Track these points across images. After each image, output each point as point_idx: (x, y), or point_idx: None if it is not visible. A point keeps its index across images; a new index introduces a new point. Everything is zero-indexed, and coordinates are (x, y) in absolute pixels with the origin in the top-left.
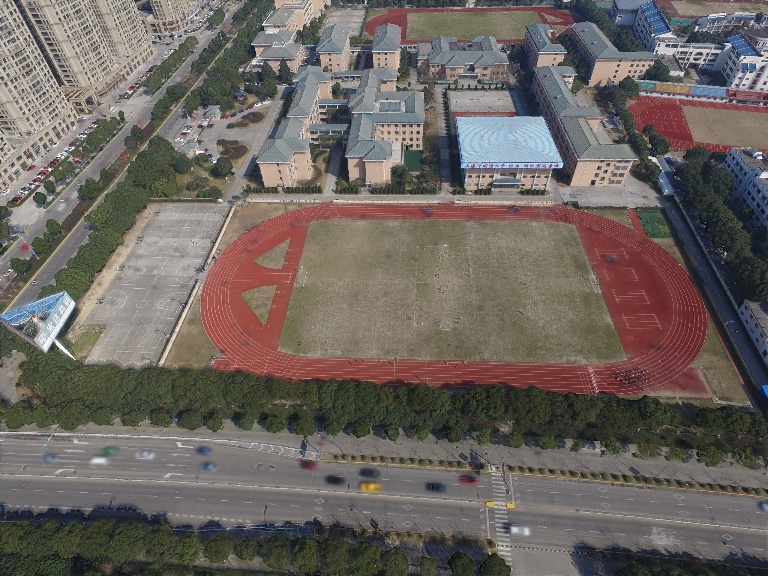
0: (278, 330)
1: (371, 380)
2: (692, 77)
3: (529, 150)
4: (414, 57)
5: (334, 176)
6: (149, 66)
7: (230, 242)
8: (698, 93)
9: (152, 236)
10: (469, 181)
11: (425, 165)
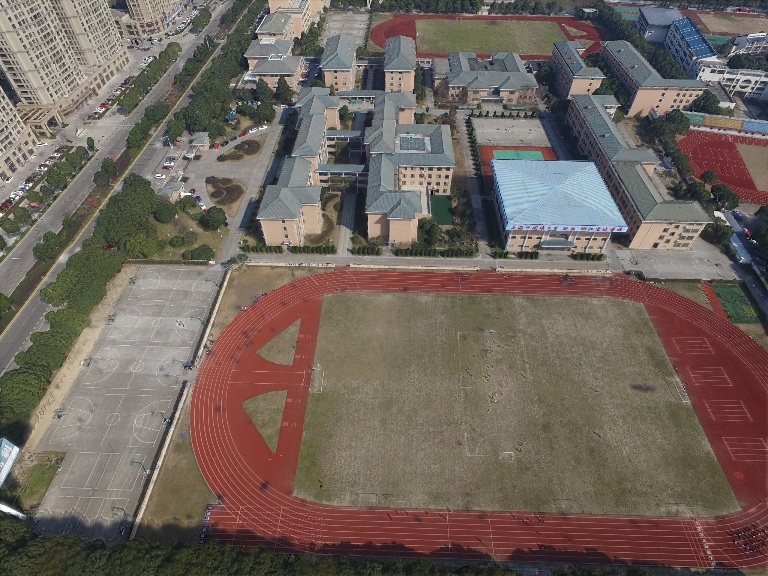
0: (292, 462)
1: (419, 545)
2: (739, 107)
3: (585, 208)
4: (428, 74)
5: (349, 230)
6: (124, 77)
7: (226, 324)
8: (752, 129)
9: (127, 313)
10: (512, 242)
11: (455, 216)
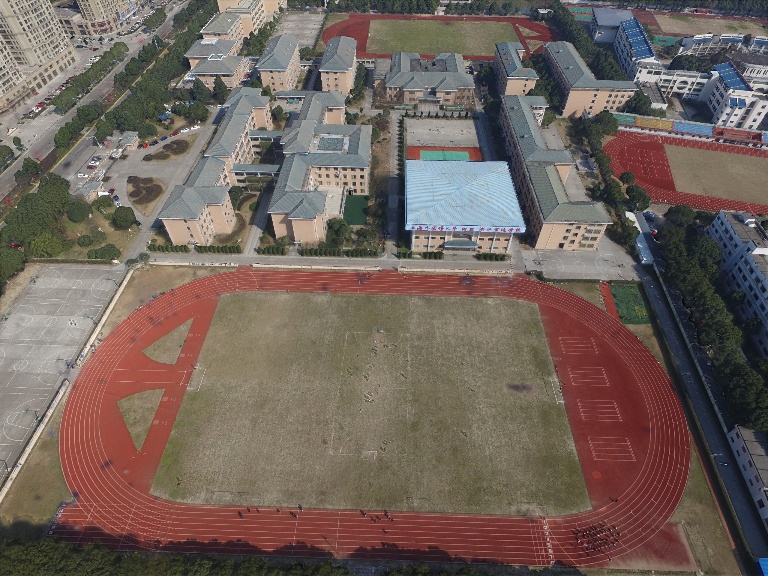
0: (155, 460)
1: (264, 543)
2: (675, 108)
3: (487, 209)
4: (372, 74)
5: (260, 229)
6: (67, 76)
7: (117, 323)
8: (682, 130)
9: (21, 312)
10: (417, 242)
11: (369, 216)
